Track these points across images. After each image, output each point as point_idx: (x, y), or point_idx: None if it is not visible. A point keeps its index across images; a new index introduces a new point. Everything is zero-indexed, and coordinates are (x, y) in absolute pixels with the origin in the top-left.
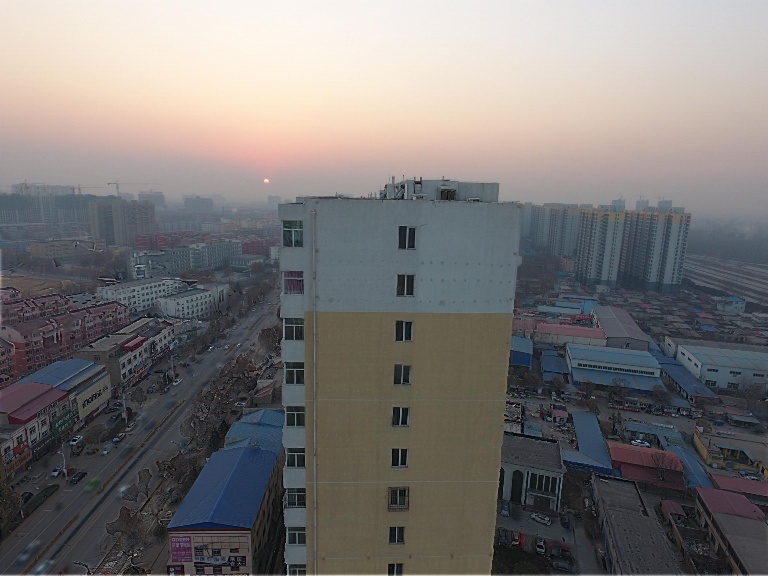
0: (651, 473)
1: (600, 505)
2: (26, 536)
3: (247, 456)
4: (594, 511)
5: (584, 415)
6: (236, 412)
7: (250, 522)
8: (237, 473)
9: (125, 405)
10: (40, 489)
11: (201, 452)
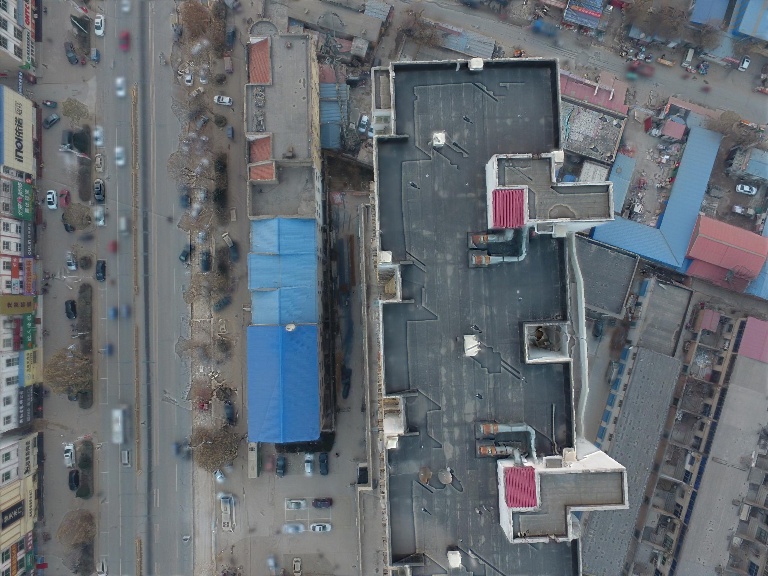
0: (720, 272)
1: (639, 327)
2: (108, 352)
3: (287, 342)
4: (631, 315)
5: (704, 141)
6: (223, 123)
7: (317, 434)
8: (286, 374)
9: (59, 102)
10: (74, 290)
11: (212, 219)
